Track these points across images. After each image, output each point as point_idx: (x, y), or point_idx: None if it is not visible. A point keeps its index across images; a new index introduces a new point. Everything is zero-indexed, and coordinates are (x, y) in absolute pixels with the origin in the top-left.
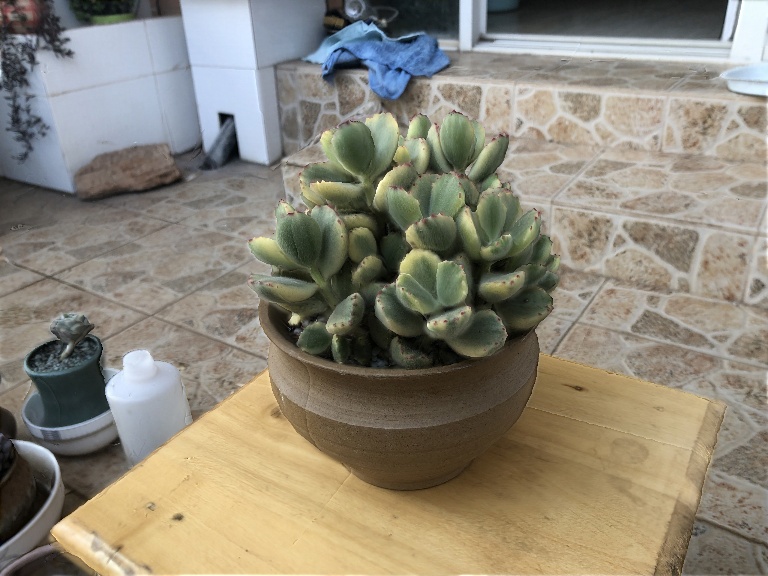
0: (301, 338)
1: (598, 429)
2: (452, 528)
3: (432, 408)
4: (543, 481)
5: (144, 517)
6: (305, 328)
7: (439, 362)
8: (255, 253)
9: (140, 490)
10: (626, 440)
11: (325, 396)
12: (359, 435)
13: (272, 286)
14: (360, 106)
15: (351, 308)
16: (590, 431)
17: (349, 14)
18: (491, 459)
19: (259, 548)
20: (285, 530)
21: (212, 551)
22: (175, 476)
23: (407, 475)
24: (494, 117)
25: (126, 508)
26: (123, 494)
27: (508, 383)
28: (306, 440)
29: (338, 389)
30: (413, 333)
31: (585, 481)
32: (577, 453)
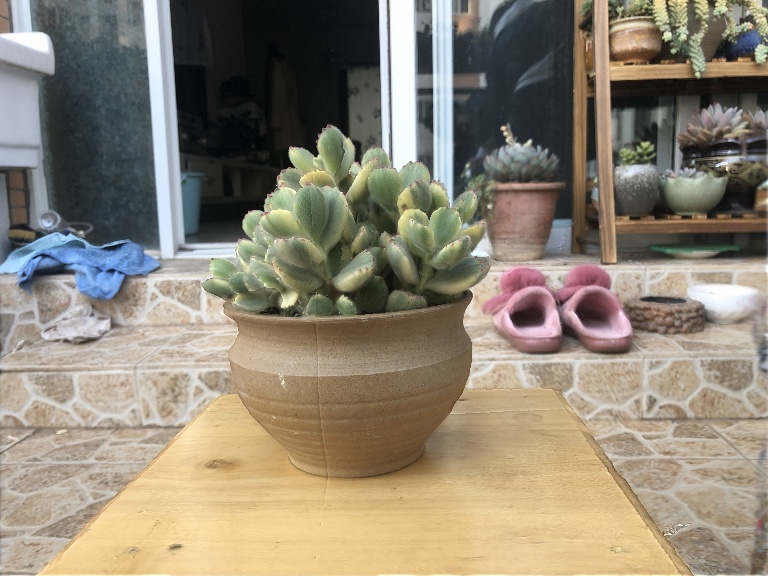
0: (309, 307)
1: (496, 413)
2: (447, 481)
3: (429, 350)
4: (486, 444)
5: (132, 559)
6: (310, 299)
7: (433, 304)
8: (271, 226)
9: (106, 544)
10: (520, 414)
11: (337, 358)
12: (377, 384)
13: (305, 240)
14: (65, 312)
15: (371, 255)
16: (492, 415)
17: (42, 227)
18: (436, 444)
19: (289, 537)
20: (303, 521)
21: (242, 552)
22: (141, 525)
23: (404, 435)
24: (216, 307)
25: (102, 559)
26: (88, 551)
27: (465, 337)
28: (262, 472)
29: (351, 346)
30: (413, 279)
31: (515, 436)
32: (495, 426)
